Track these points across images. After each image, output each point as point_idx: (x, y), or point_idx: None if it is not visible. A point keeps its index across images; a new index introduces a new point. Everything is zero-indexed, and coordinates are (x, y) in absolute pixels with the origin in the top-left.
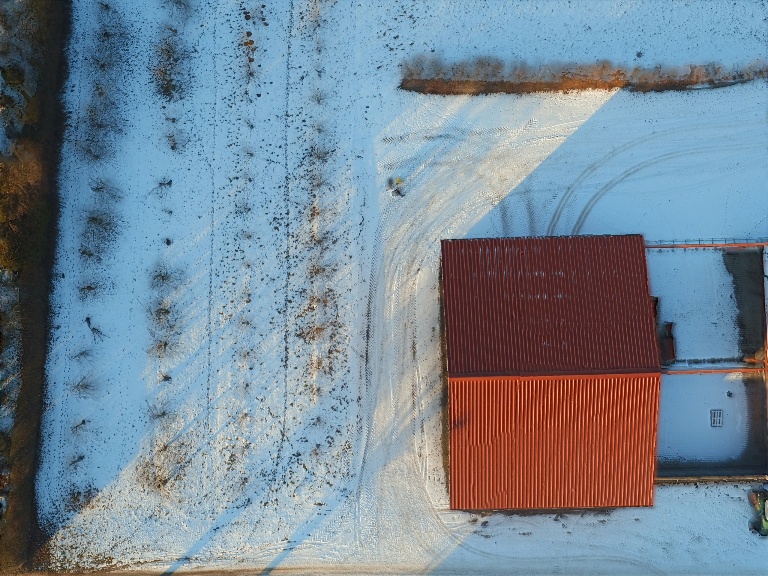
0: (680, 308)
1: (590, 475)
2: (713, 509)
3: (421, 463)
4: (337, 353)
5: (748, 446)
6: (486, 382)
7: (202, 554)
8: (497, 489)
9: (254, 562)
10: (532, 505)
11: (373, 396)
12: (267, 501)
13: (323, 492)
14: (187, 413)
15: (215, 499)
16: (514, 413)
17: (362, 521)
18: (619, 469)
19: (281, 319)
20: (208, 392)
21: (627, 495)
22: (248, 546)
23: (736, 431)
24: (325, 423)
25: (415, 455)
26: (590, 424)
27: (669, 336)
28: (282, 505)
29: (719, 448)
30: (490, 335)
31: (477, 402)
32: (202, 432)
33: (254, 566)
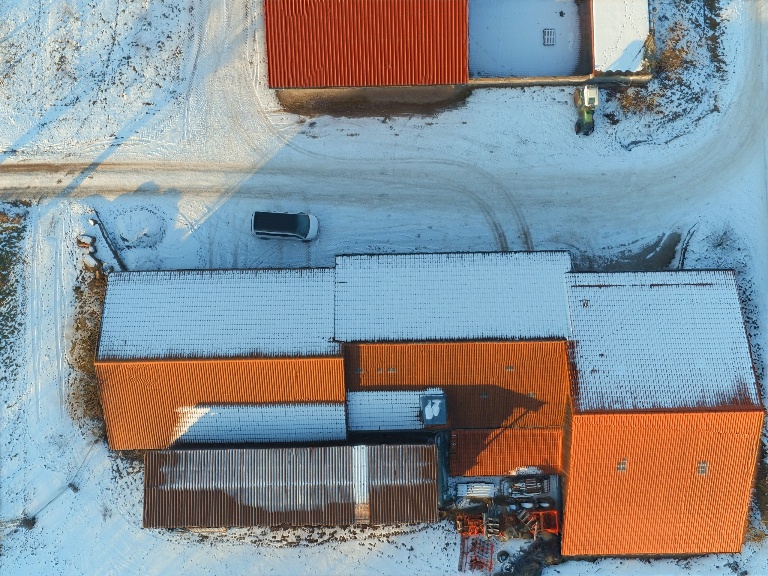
0: None
1: (406, 50)
2: (540, 113)
3: (252, 70)
4: None
5: (580, 65)
6: None
7: (29, 147)
8: (315, 65)
9: (81, 157)
10: (350, 83)
11: (206, 8)
12: (96, 100)
13: (152, 92)
14: (18, 16)
15: (44, 97)
16: None
17: (191, 121)
18: (434, 43)
19: None
20: None
21: (444, 72)
22: (75, 141)
23: (569, 50)
24: (156, 29)
25: (246, 62)
26: None
27: None
28: (111, 104)
29: (552, 68)
30: None
31: None
32: (33, 34)
33: (81, 160)
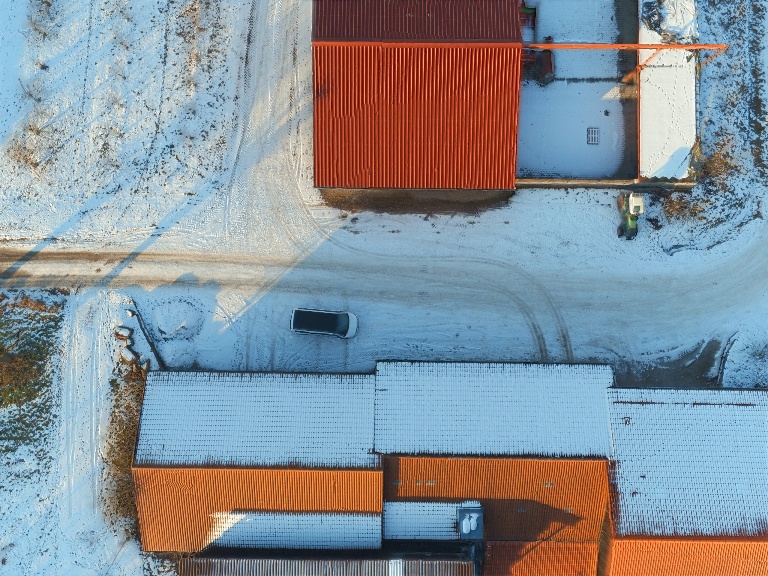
0: (561, 28)
1: (453, 154)
2: (583, 215)
3: (295, 162)
4: (216, 53)
5: (624, 165)
6: (349, 48)
7: (69, 235)
8: (360, 166)
9: (121, 246)
10: (395, 185)
11: (251, 97)
12: (138, 189)
13: (194, 183)
14: (62, 101)
15: (86, 184)
16: (377, 83)
17: (232, 213)
18: (481, 148)
19: (162, 18)
20: (85, 83)
21: (490, 177)
22: (116, 230)
23: (612, 150)
24: (200, 118)
25: (289, 154)
26: (452, 98)
27: (547, 50)
28: (152, 193)
29: (595, 167)
30: (356, 6)
31: (340, 70)
32: (76, 120)
33: (121, 250)
